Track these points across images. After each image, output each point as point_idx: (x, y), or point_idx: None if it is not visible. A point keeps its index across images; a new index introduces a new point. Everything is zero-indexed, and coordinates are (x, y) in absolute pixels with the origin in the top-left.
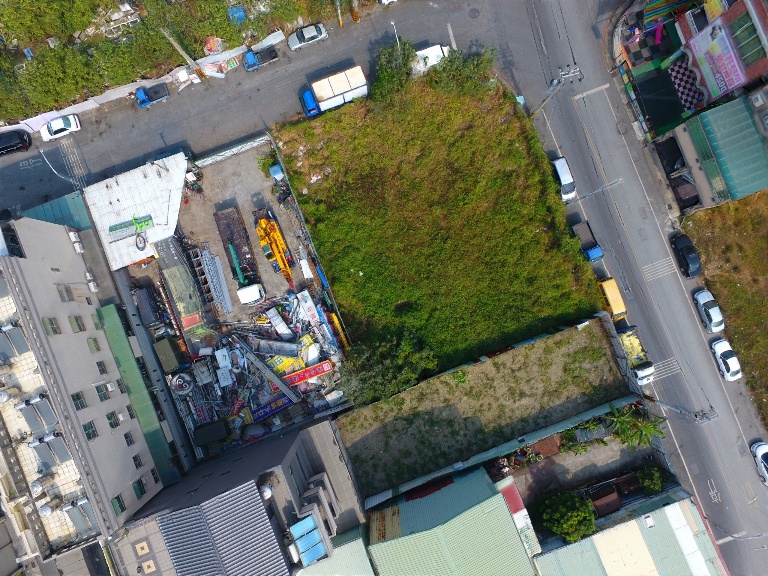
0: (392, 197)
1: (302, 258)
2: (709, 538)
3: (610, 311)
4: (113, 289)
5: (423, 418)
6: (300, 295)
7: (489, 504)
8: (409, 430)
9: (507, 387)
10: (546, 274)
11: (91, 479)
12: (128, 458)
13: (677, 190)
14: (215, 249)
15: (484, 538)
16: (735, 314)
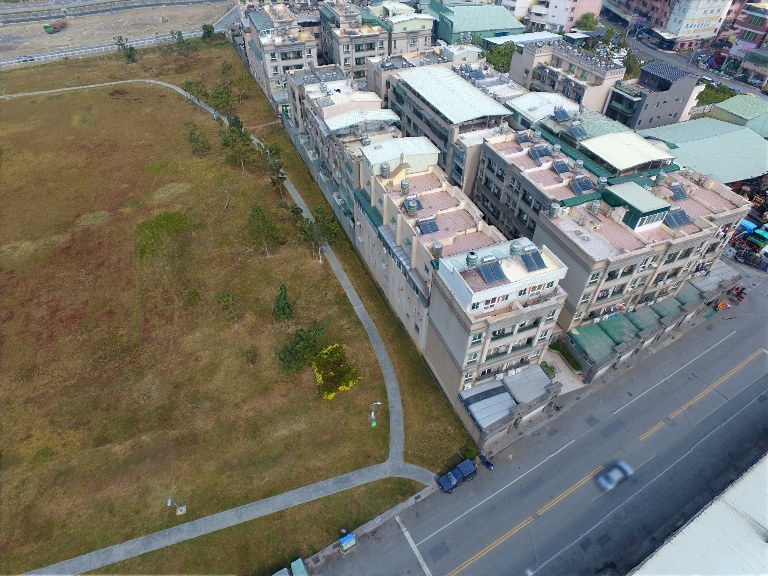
0: None
1: None
2: None
3: None
4: None
5: None
6: None
7: None
8: None
9: None
10: None
11: None
12: None
13: (753, 85)
14: None
15: None
16: None
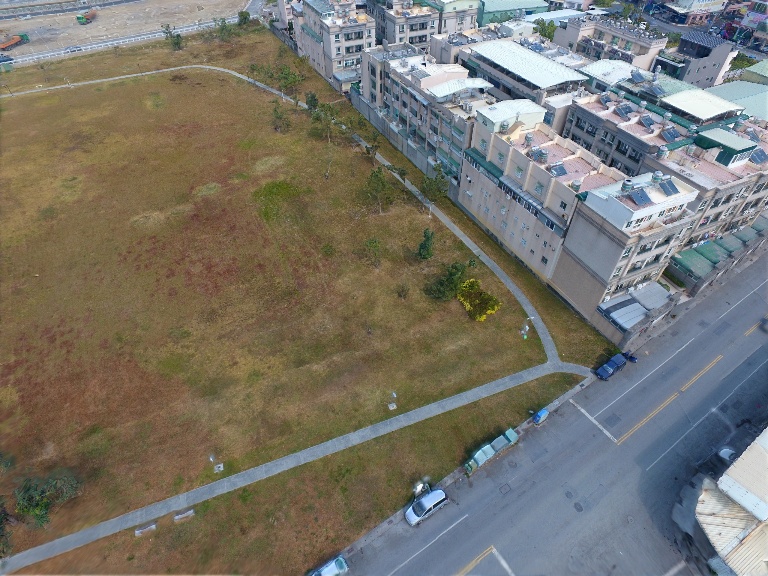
0: None
1: None
2: None
3: None
4: None
5: None
6: None
7: None
8: None
9: None
10: None
11: None
12: None
13: None
14: None
15: None
16: None
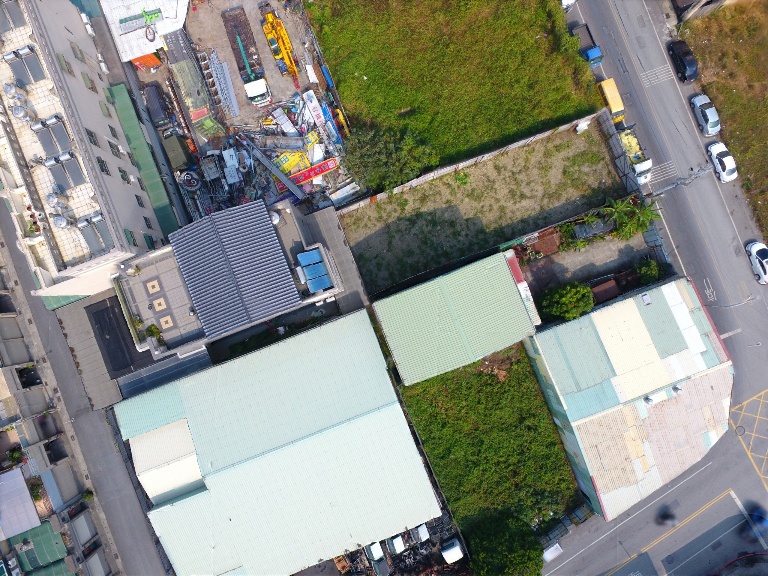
0: (396, 4)
1: (308, 64)
2: (704, 314)
3: (609, 111)
4: (123, 75)
5: (426, 218)
6: (306, 95)
7: (490, 261)
8: (412, 230)
9: (508, 189)
10: (546, 78)
11: (105, 200)
12: (139, 213)
13: None
14: (222, 55)
15: (485, 292)
16: (731, 118)
